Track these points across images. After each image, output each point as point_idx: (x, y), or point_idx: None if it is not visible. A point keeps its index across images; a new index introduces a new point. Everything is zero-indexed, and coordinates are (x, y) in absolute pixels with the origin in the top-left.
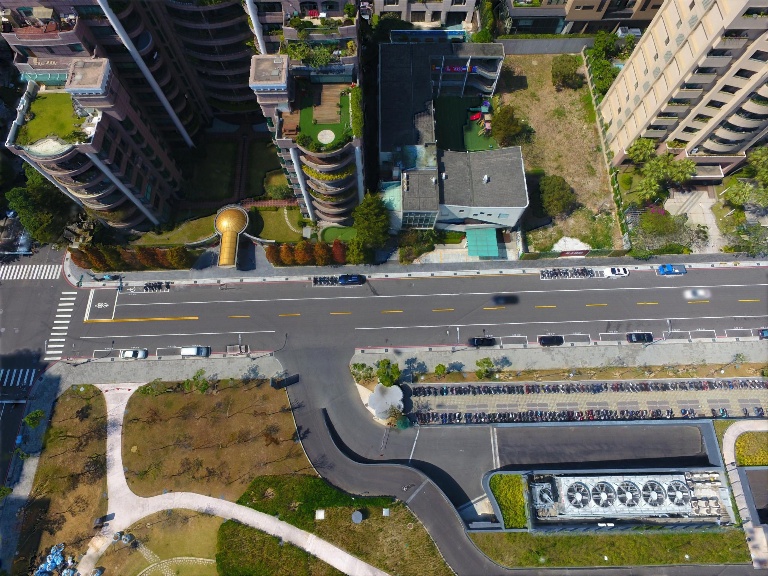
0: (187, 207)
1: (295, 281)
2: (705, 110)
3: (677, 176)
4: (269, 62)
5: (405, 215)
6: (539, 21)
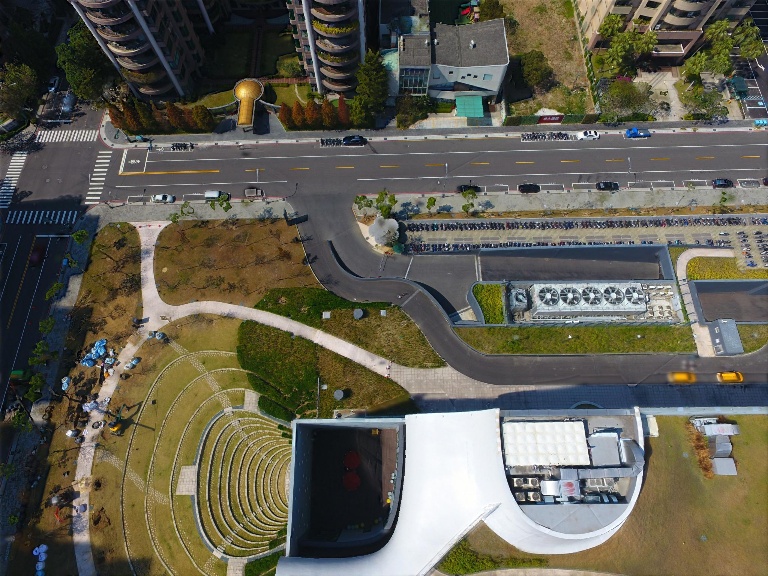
0: (209, 83)
1: (304, 143)
2: None
3: (641, 47)
4: None
5: (401, 73)
6: None
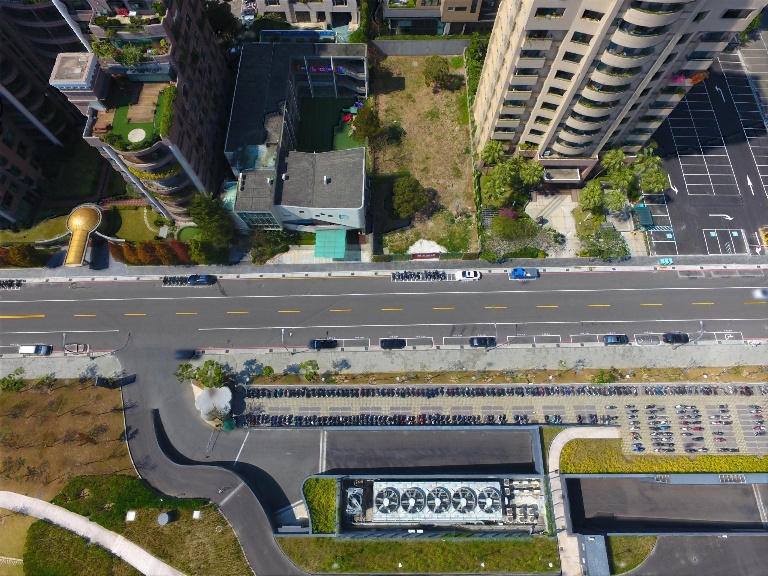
0: (48, 205)
1: (146, 280)
2: (542, 112)
3: (525, 179)
4: (74, 60)
5: (241, 215)
6: (417, 22)
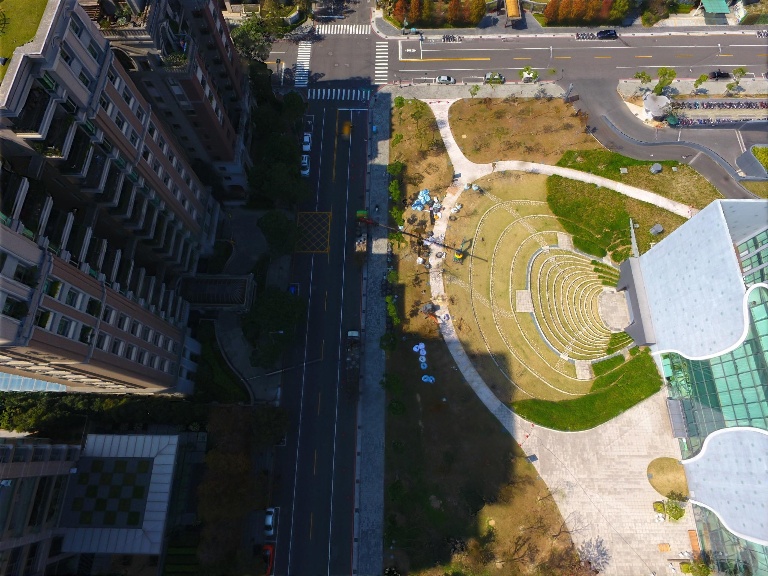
0: None
1: (561, 37)
2: None
3: None
4: None
5: None
6: None
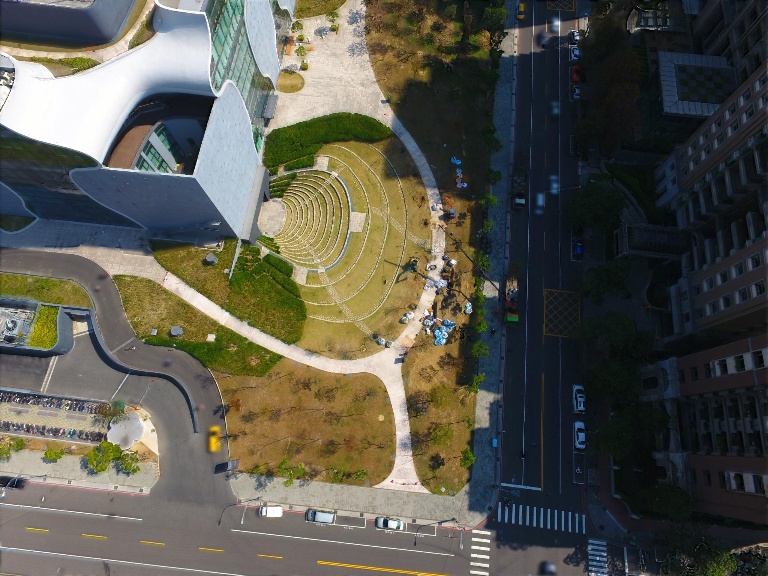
0: None
1: None
2: None
3: None
4: None
5: None
6: None
